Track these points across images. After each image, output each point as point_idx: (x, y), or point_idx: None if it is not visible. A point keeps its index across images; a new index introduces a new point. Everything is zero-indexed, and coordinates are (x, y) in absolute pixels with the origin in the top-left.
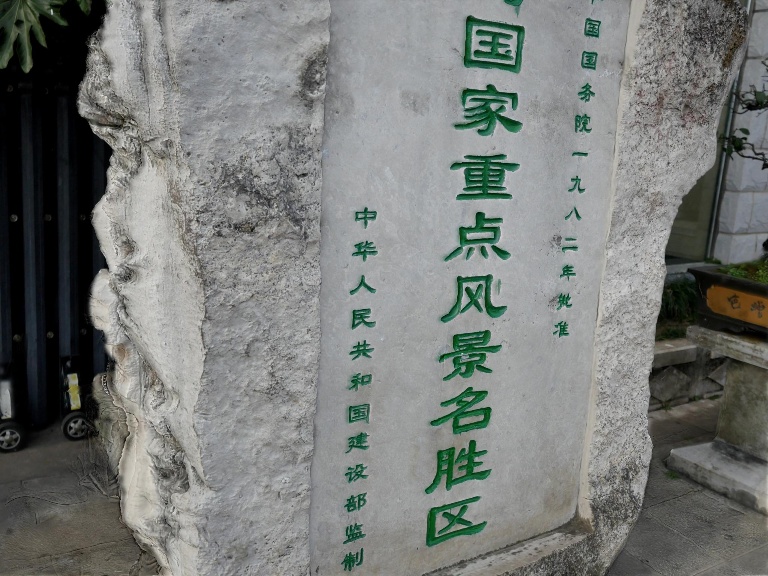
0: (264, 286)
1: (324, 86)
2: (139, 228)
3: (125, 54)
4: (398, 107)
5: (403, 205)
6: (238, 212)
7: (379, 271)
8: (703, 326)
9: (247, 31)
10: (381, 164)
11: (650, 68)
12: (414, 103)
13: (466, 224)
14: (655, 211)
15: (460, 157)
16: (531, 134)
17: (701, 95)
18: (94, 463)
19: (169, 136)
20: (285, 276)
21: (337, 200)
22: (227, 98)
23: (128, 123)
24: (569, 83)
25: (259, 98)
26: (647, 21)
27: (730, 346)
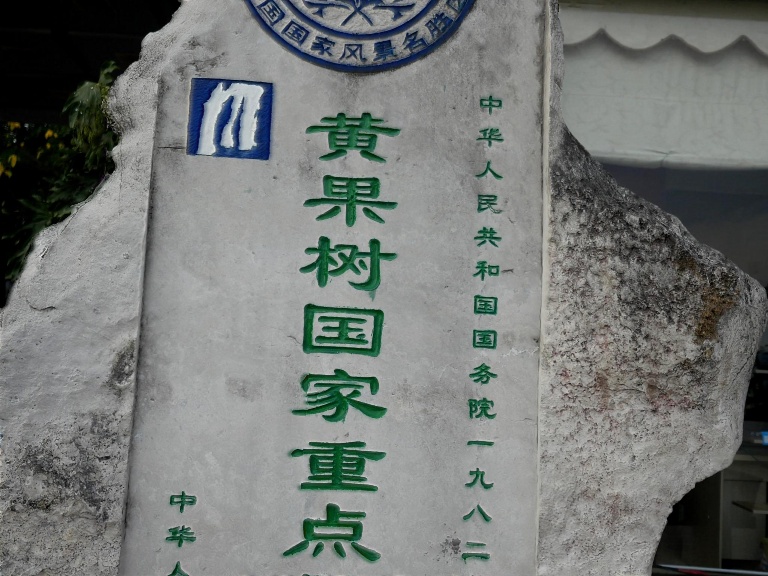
0: (57, 562)
1: (132, 376)
2: None
3: None
4: (224, 393)
5: (231, 491)
6: (34, 489)
7: (198, 559)
8: None
9: (64, 332)
10: (201, 449)
11: (573, 345)
12: (244, 389)
13: (312, 516)
14: (620, 517)
15: (304, 443)
16: (402, 420)
17: (672, 373)
18: None
19: None
20: (81, 554)
21: (152, 482)
22: (39, 389)
23: None
24: (454, 364)
25: (69, 388)
26: (558, 294)
27: None
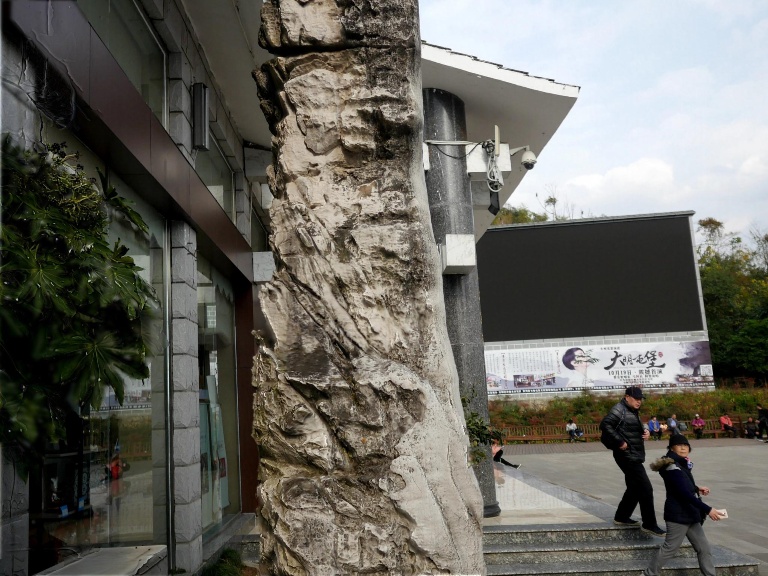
0: None
1: None
2: None
3: (439, 512)
4: None
5: None
6: None
7: None
8: None
9: None
10: None
11: None
12: None
13: None
14: None
15: None
16: None
17: None
18: None
19: (473, 575)
20: None
21: None
22: None
23: (395, 575)
24: None
25: None
26: None
27: None
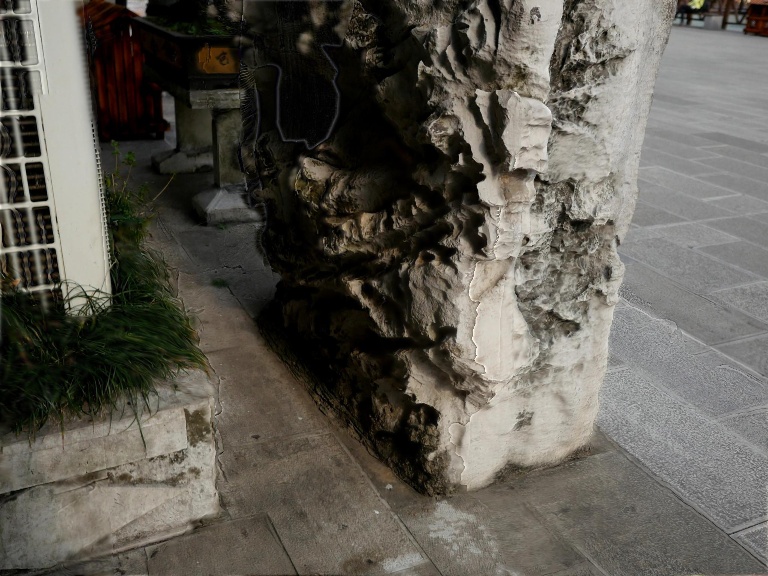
0: None
1: None
2: (627, 8)
3: None
4: None
5: None
6: None
7: None
8: (203, 89)
9: None
10: None
11: None
12: None
13: None
14: None
15: None
16: None
17: None
18: (131, 521)
19: None
20: None
21: None
22: None
23: None
24: None
25: None
26: None
27: (235, 98)
